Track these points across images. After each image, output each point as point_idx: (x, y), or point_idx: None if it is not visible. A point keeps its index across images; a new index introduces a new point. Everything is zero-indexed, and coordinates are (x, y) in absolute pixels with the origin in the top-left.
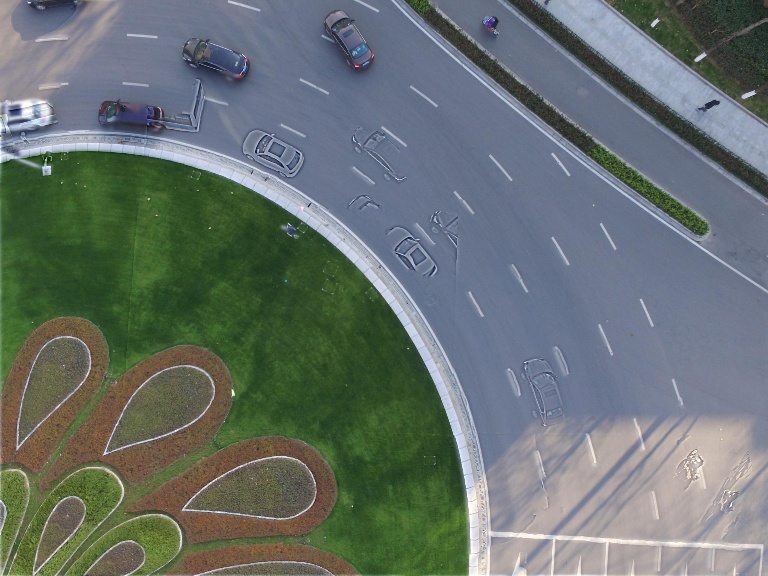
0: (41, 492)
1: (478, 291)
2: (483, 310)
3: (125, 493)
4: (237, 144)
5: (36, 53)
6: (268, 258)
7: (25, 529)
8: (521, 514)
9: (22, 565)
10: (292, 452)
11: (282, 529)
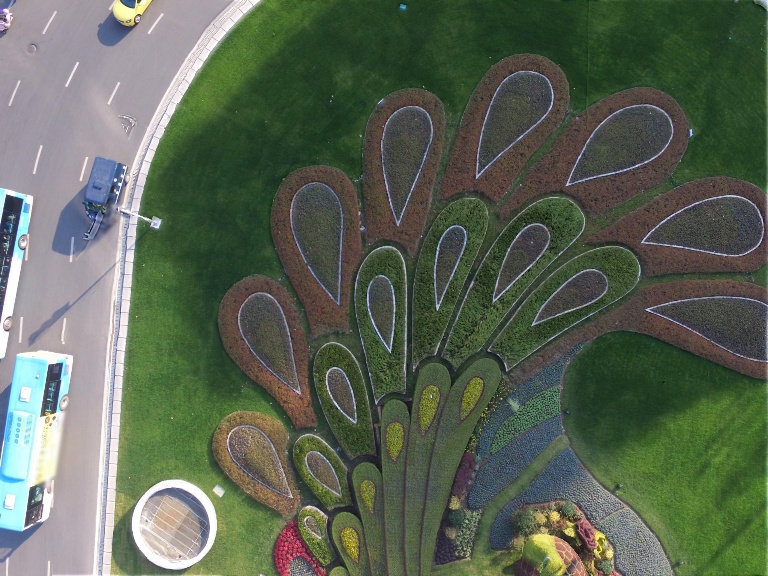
0: (500, 221)
1: None
2: None
3: (585, 225)
4: None
5: None
6: (712, 17)
7: (480, 259)
8: None
9: (482, 292)
10: (745, 192)
11: (735, 264)
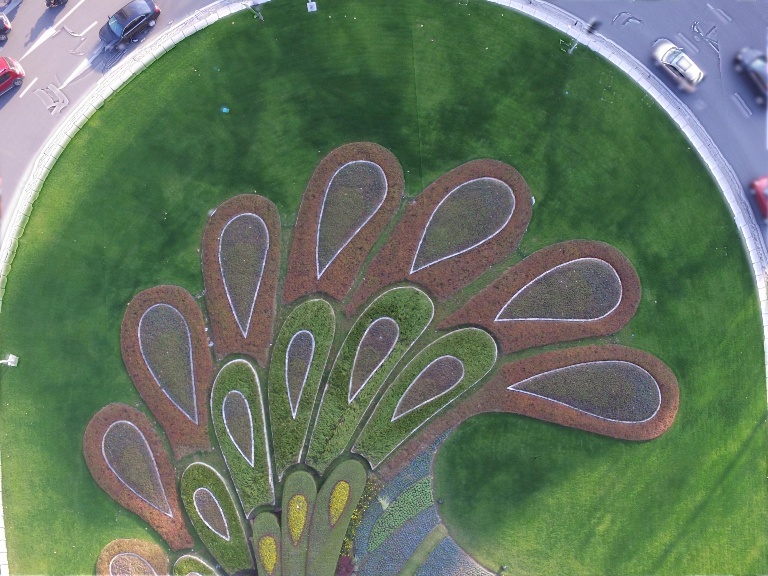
0: (347, 319)
1: (744, 91)
2: (751, 108)
3: (435, 310)
4: None
5: None
6: (546, 73)
7: (333, 360)
8: None
9: (337, 394)
10: (597, 252)
11: (594, 329)
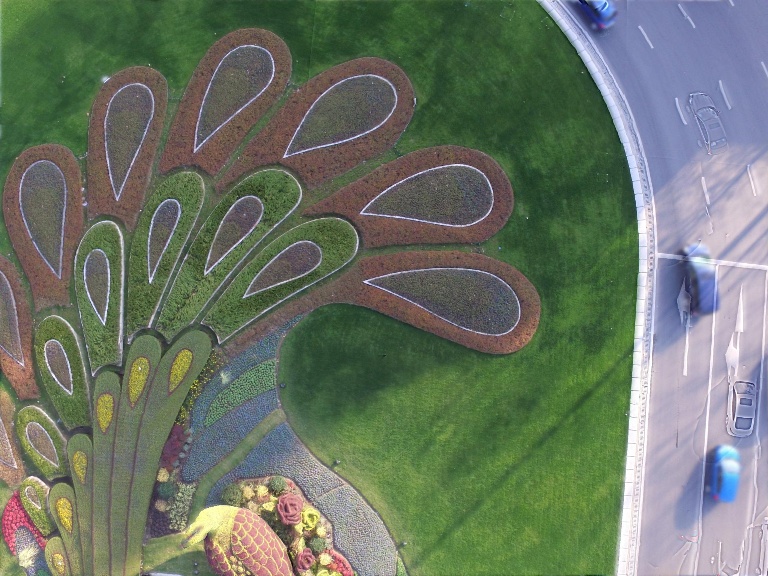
0: (216, 194)
1: (648, 25)
2: (653, 42)
3: (302, 196)
4: None
5: None
6: None
7: (197, 232)
8: (687, 239)
9: (194, 264)
10: (472, 160)
11: (459, 235)
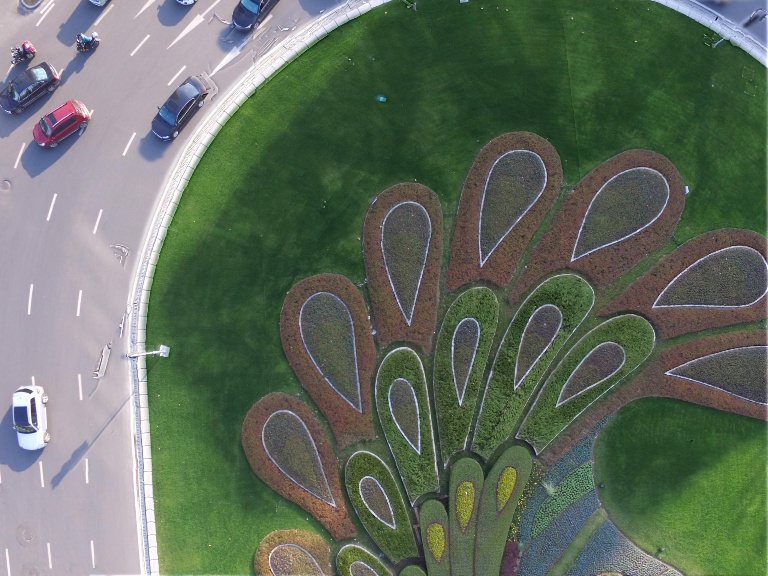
0: (510, 306)
1: None
2: None
3: (595, 297)
4: None
5: None
6: (692, 66)
7: (496, 347)
8: None
9: (502, 381)
10: (747, 240)
11: (746, 315)
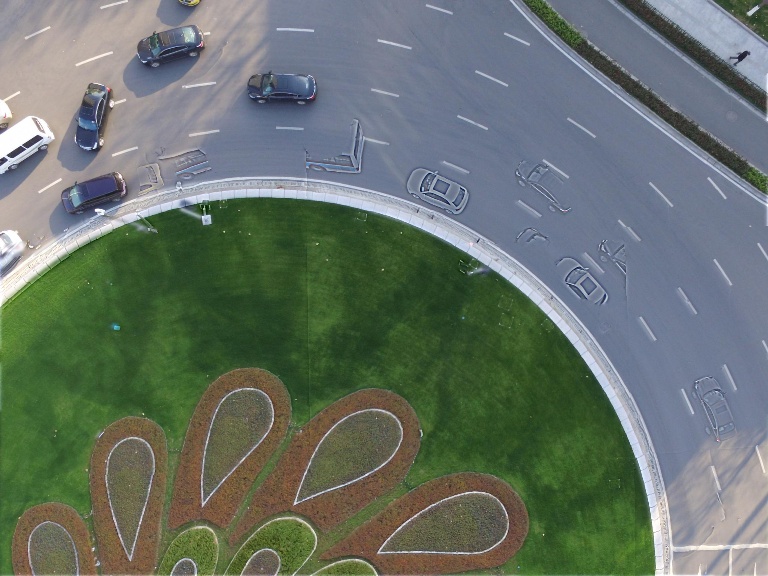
0: (231, 547)
1: (649, 316)
2: (655, 334)
3: (318, 541)
4: (401, 183)
5: (185, 99)
6: (443, 296)
7: None
8: (700, 527)
9: None
10: (484, 487)
11: (478, 563)
